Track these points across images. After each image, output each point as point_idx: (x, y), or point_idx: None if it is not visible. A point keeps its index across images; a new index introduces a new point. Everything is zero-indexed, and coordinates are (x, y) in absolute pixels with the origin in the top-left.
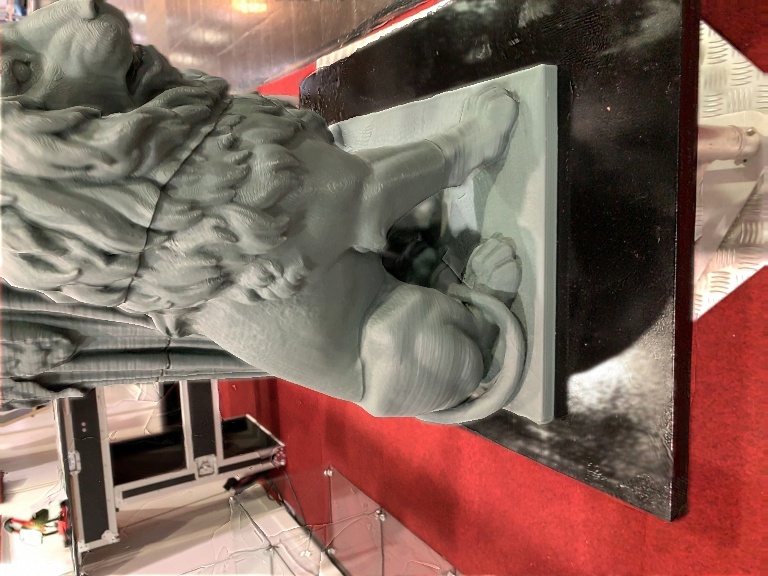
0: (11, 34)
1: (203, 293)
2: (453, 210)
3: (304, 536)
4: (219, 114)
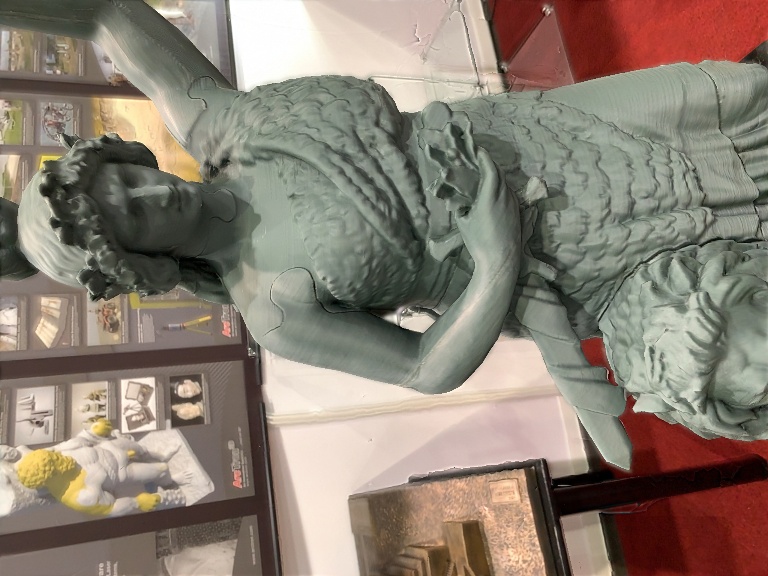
0: None
1: None
2: None
3: (506, 86)
4: None
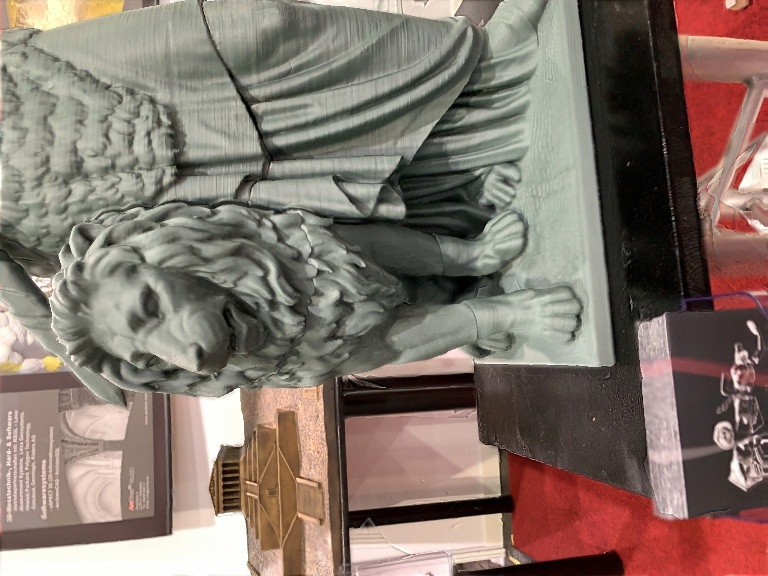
0: (144, 350)
1: None
2: (510, 277)
3: None
4: (287, 354)
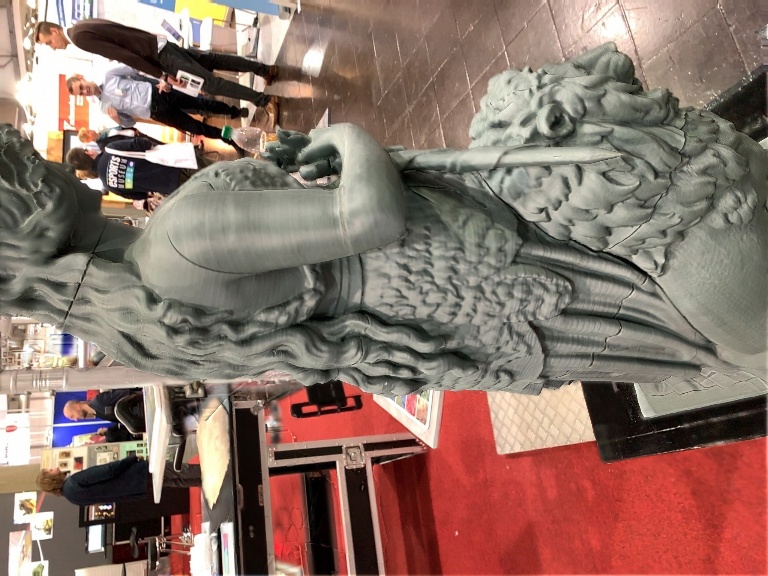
0: None
1: (702, 209)
2: None
3: None
4: None
